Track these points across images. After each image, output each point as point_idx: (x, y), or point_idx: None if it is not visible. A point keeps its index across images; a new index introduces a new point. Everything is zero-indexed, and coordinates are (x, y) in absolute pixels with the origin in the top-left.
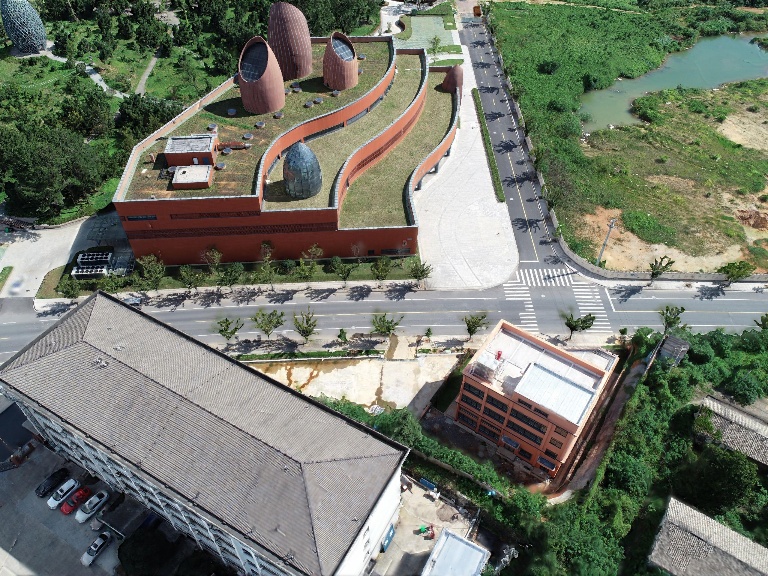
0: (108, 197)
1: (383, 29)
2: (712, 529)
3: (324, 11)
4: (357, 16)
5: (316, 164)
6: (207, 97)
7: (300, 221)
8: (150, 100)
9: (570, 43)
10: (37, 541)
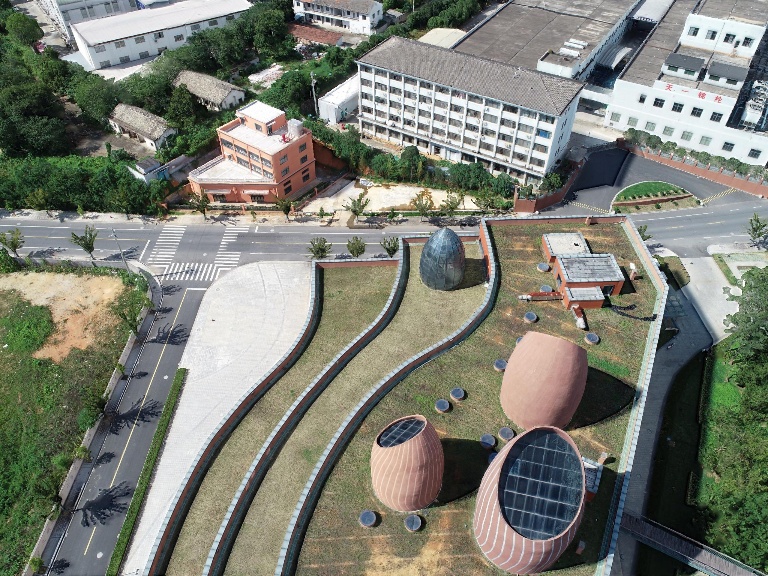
0: (715, 374)
1: None
2: (211, 92)
3: None
4: None
5: None
6: (641, 404)
7: None
8: None
9: None
10: None
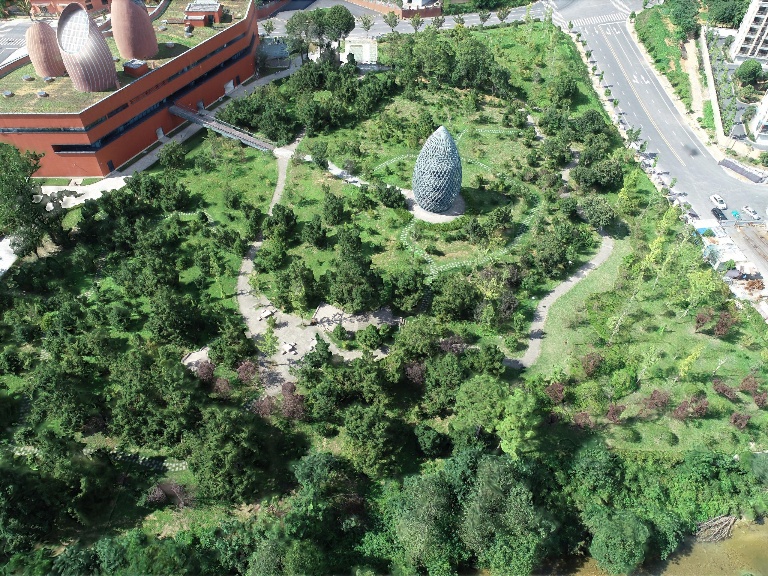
0: None
1: None
2: None
3: None
4: None
5: None
6: None
7: None
8: (255, 106)
9: None
10: None
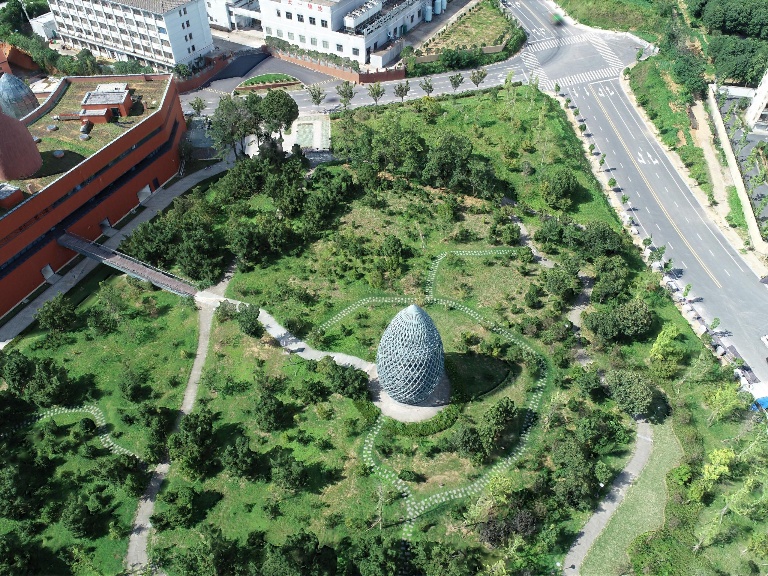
0: None
1: None
2: None
3: None
4: None
5: None
6: (80, 164)
7: None
8: (170, 235)
9: None
10: (215, 42)
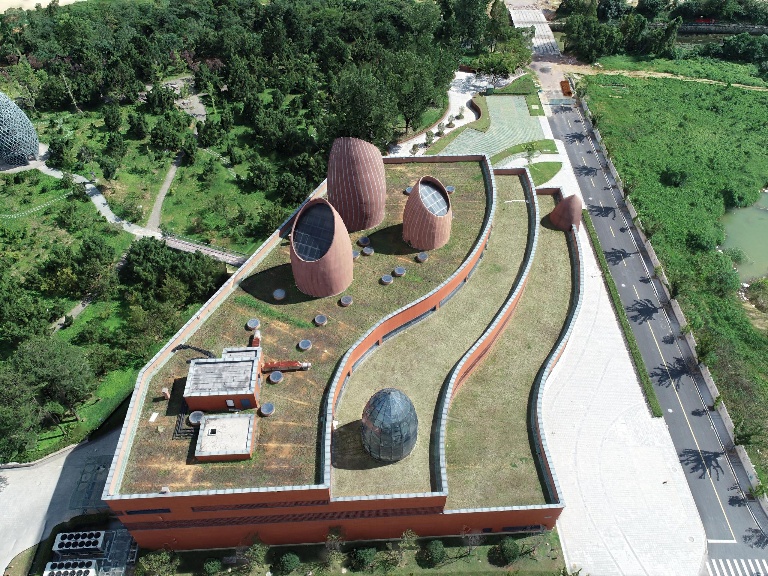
0: (105, 407)
1: (453, 113)
2: None
3: (389, 109)
4: (426, 106)
5: (413, 419)
6: (244, 267)
7: (388, 507)
8: (166, 249)
9: (692, 136)
10: None
